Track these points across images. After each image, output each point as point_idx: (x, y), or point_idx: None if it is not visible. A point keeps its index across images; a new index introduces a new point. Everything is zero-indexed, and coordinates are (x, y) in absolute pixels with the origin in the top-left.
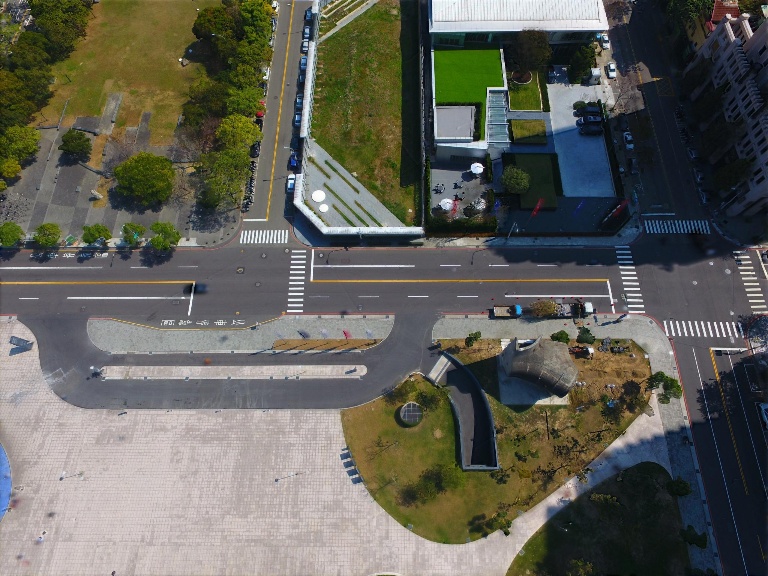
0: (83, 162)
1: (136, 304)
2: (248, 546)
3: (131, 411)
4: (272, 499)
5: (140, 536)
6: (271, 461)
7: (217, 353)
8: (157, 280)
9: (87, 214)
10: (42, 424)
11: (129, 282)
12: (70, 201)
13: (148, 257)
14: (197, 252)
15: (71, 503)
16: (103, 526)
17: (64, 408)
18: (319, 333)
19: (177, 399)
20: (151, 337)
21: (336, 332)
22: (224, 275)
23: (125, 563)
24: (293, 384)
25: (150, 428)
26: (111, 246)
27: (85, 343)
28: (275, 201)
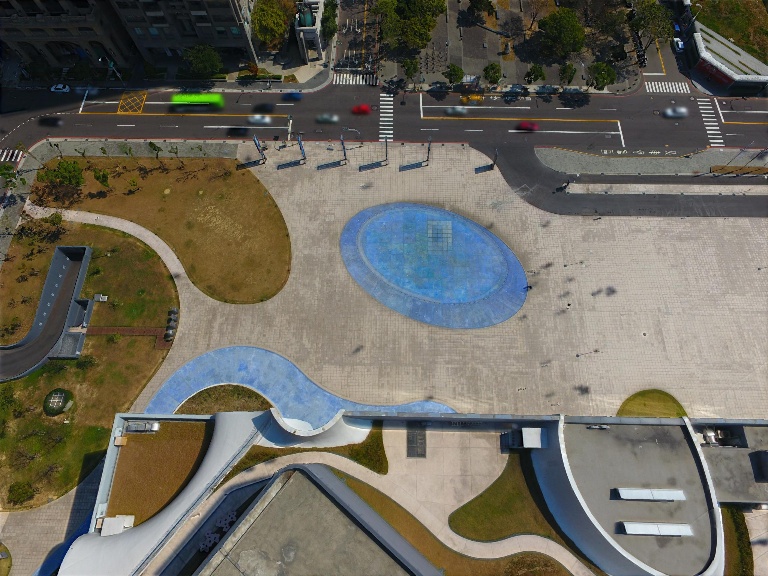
0: (481, 24)
1: (572, 137)
2: (756, 316)
3: (604, 217)
4: (762, 283)
5: (656, 308)
6: (748, 255)
7: (663, 175)
8: (584, 119)
9: (500, 65)
10: (528, 225)
11: (559, 120)
12: (481, 55)
13: (568, 101)
14: (611, 98)
15: (583, 283)
16: (619, 300)
17: (542, 214)
18: (747, 162)
19: (642, 209)
20: (598, 162)
21: (762, 162)
22: (643, 116)
23: (652, 327)
24: (742, 199)
25: (627, 230)
26: (531, 91)
27: (539, 166)
28: (666, 59)
